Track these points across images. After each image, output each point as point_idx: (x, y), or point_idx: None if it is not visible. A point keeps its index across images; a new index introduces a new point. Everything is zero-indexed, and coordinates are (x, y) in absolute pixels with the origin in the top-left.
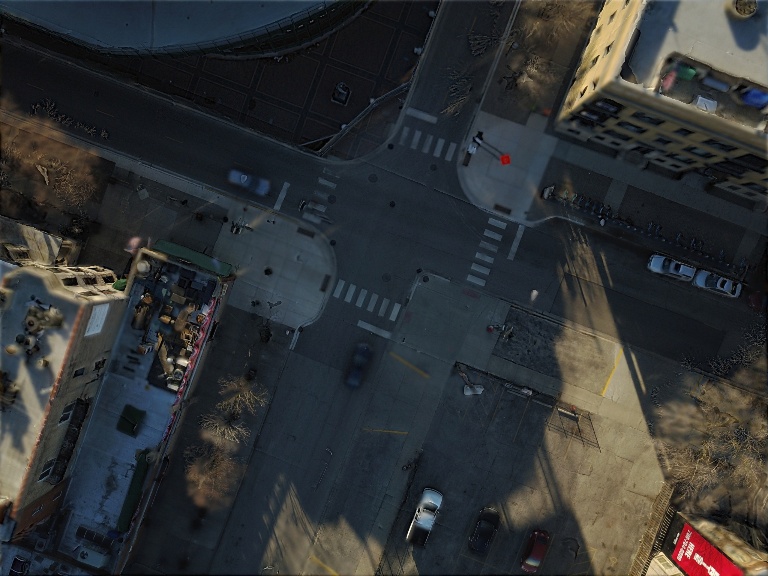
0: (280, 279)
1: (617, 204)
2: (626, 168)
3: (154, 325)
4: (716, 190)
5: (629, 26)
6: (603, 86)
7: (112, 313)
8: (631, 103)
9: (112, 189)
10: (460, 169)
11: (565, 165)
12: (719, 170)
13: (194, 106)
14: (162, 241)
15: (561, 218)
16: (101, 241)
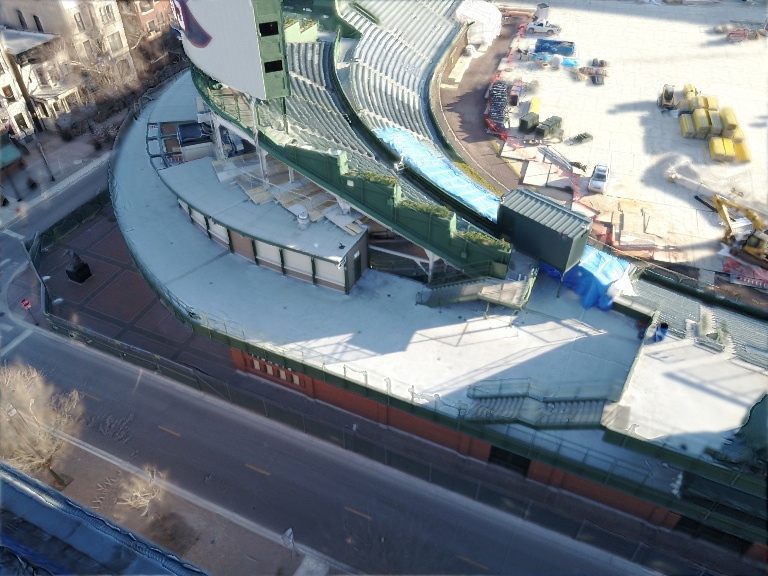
0: None
1: None
2: None
3: None
4: None
5: None
6: None
7: None
8: None
9: (94, 148)
10: None
11: None
12: None
13: None
14: (19, 154)
15: None
16: (56, 141)
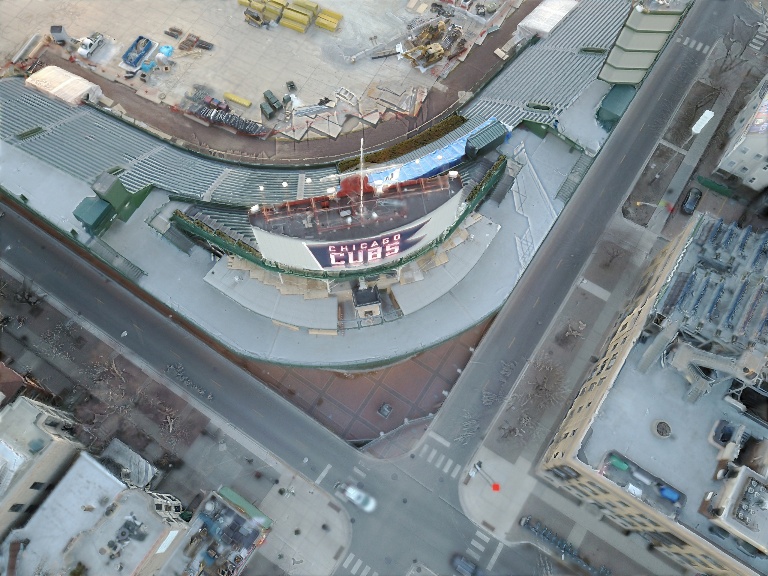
0: (305, 541)
1: (577, 544)
2: (586, 516)
3: (200, 556)
4: (656, 551)
5: (586, 425)
6: (566, 459)
7: (176, 538)
8: (585, 475)
9: (201, 438)
10: (461, 486)
11: (540, 502)
12: (653, 537)
13: (279, 393)
14: (227, 488)
15: (533, 544)
16: (179, 475)
